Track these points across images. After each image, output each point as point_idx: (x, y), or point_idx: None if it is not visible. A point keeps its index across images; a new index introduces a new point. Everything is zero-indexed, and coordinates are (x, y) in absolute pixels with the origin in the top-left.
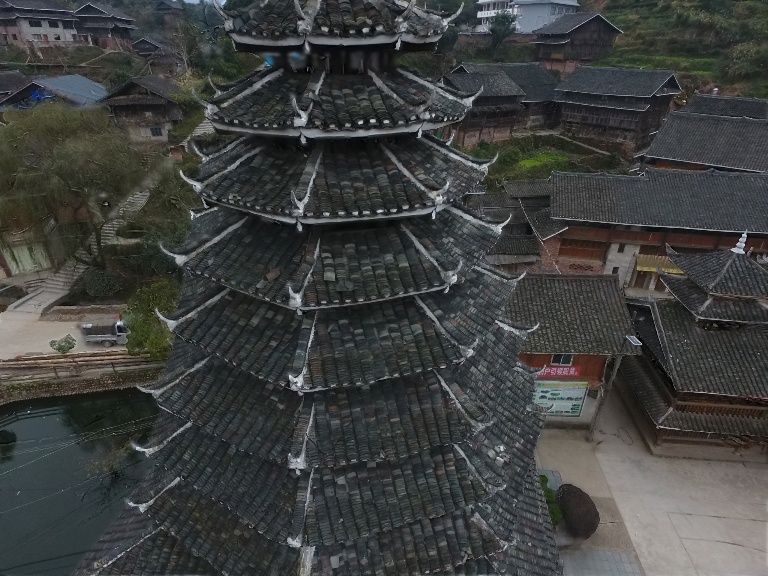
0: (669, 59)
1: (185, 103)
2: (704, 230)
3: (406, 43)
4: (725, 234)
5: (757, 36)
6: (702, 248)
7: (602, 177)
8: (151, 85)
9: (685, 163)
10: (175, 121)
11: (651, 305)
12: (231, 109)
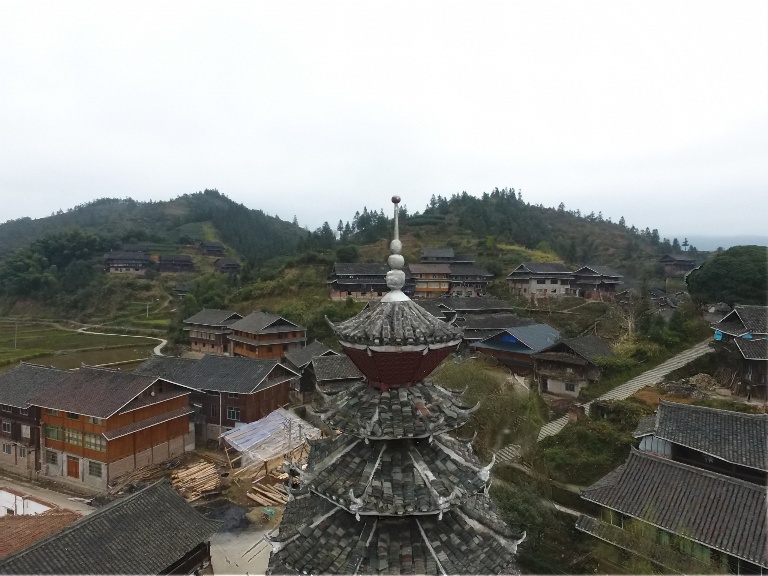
0: None
1: (606, 366)
2: None
3: (374, 515)
4: None
5: None
6: None
7: None
8: (580, 346)
9: None
10: (591, 380)
11: None
12: (298, 503)
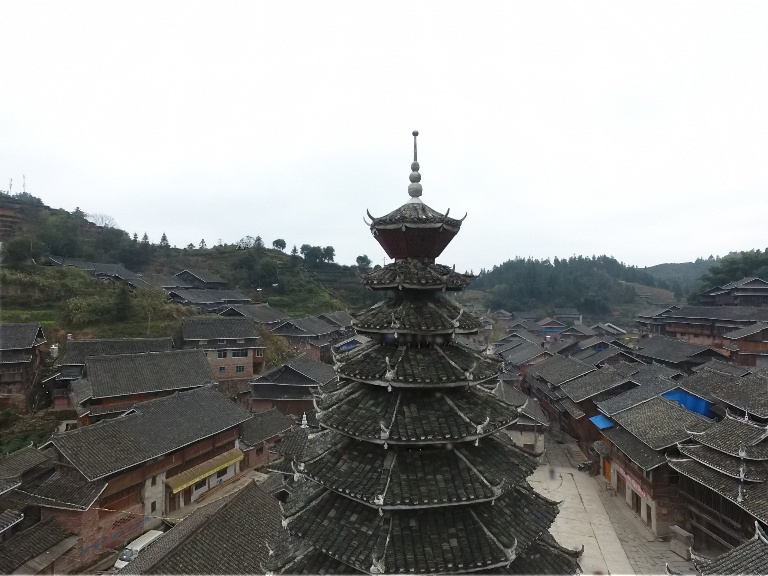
0: (5, 312)
1: None
2: (209, 436)
3: None
4: (217, 434)
5: (79, 293)
6: (207, 451)
7: (105, 424)
8: None
9: (132, 395)
10: None
11: (285, 488)
12: None
